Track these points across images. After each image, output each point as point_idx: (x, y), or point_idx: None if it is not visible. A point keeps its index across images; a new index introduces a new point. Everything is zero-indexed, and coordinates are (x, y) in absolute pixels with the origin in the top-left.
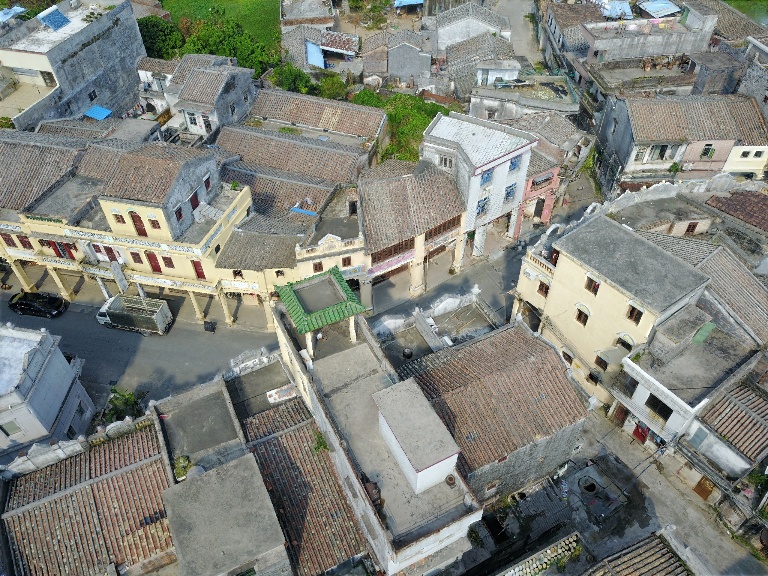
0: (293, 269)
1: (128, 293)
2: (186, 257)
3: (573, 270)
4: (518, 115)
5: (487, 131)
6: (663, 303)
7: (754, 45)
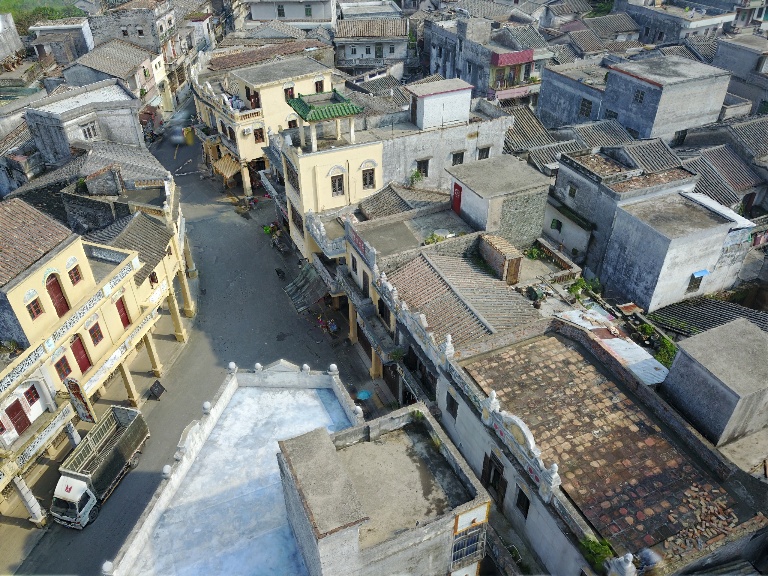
0: (173, 236)
1: (22, 509)
2: (112, 301)
3: (274, 94)
4: (8, 127)
5: (78, 97)
6: (323, 68)
7: (41, 30)
